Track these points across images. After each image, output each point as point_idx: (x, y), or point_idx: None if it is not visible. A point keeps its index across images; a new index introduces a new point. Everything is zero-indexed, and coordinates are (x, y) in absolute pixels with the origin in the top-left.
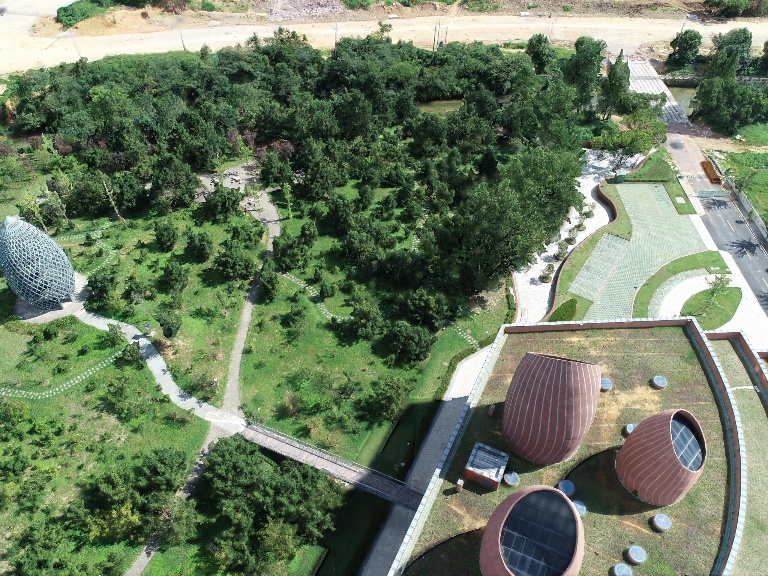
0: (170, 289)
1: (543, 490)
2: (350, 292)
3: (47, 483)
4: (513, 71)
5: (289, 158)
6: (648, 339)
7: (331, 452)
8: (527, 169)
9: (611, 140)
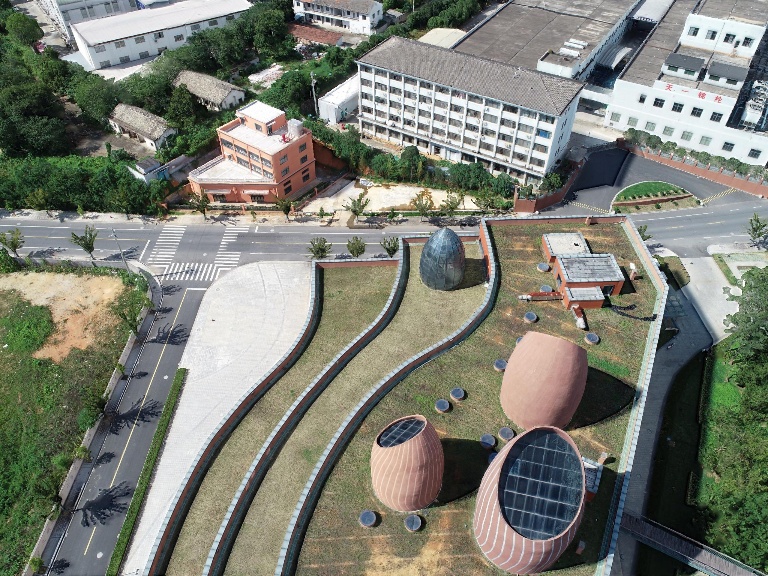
0: None
1: None
2: None
3: None
4: None
5: None
6: None
7: None
8: None
9: None
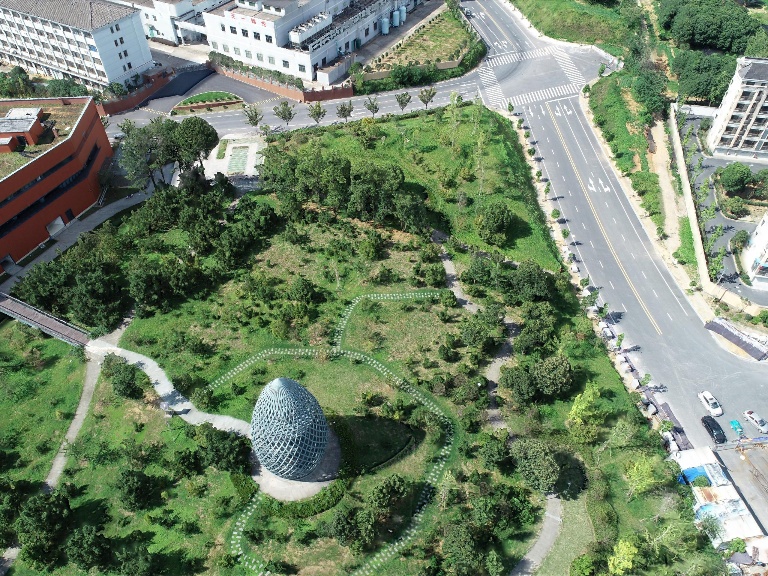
0: None
1: None
2: None
3: None
4: None
5: None
6: None
7: None
8: None
9: None
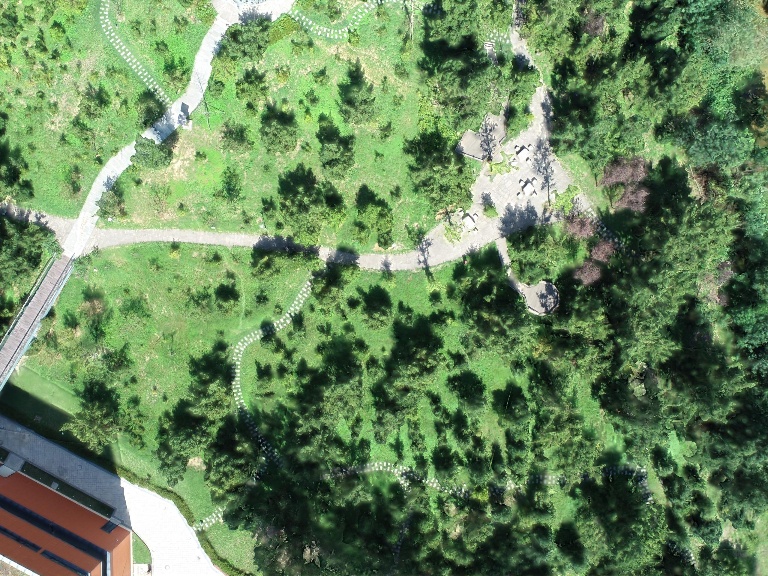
0: None
1: None
2: None
3: None
4: None
5: None
6: None
7: (50, 351)
8: None
9: None
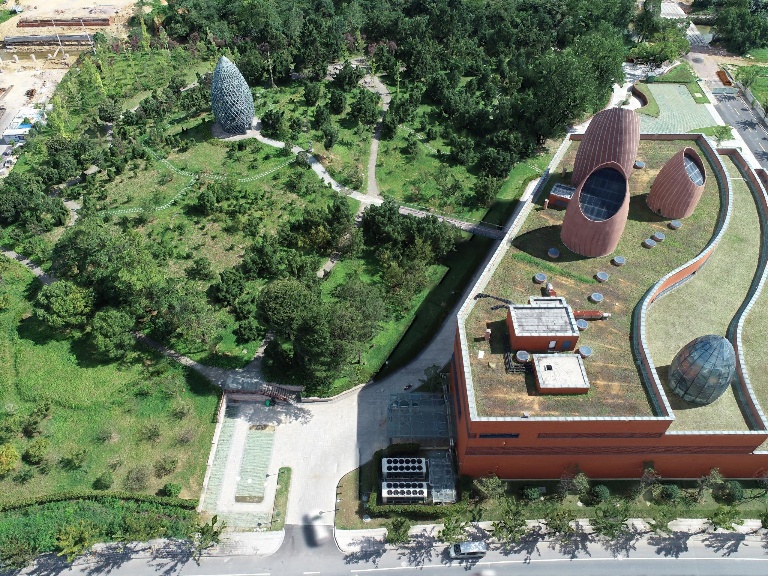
0: (319, 127)
1: (606, 169)
2: (447, 138)
3: (260, 223)
4: (564, 5)
5: None
6: (670, 146)
7: None
8: (583, 48)
9: (645, 50)
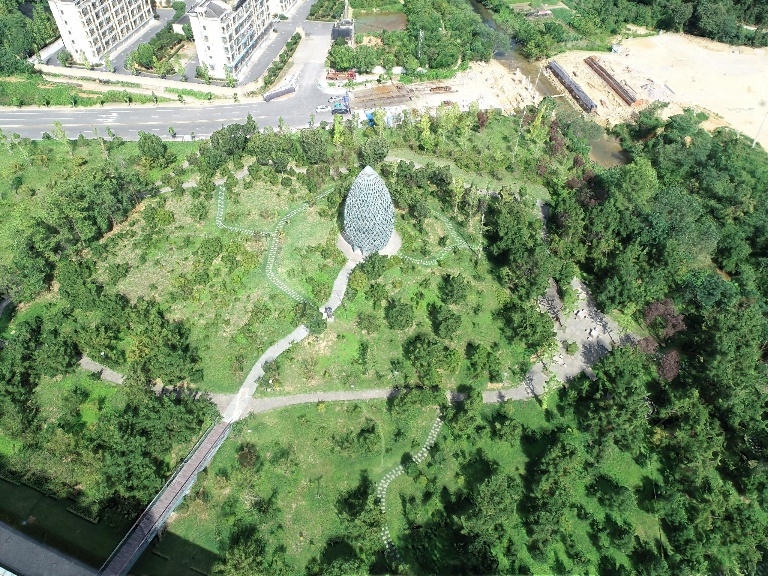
0: None
1: None
2: None
3: None
4: None
5: (675, 383)
6: None
7: None
8: None
9: None
